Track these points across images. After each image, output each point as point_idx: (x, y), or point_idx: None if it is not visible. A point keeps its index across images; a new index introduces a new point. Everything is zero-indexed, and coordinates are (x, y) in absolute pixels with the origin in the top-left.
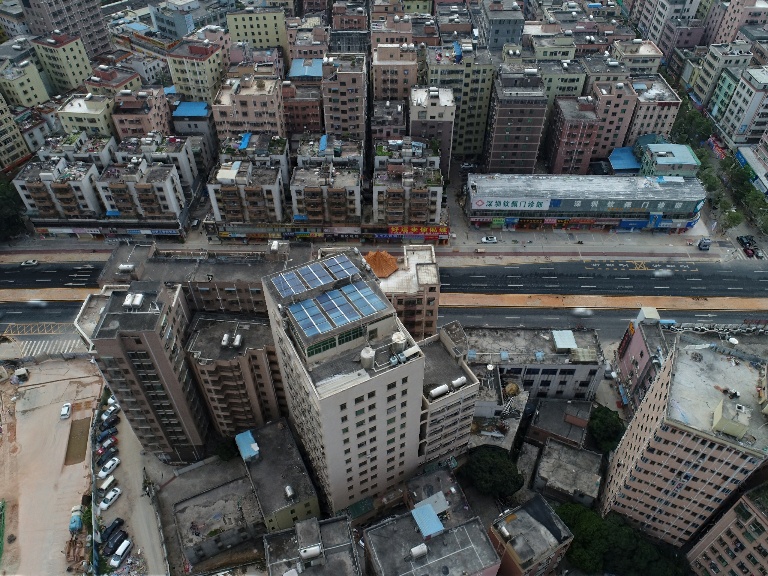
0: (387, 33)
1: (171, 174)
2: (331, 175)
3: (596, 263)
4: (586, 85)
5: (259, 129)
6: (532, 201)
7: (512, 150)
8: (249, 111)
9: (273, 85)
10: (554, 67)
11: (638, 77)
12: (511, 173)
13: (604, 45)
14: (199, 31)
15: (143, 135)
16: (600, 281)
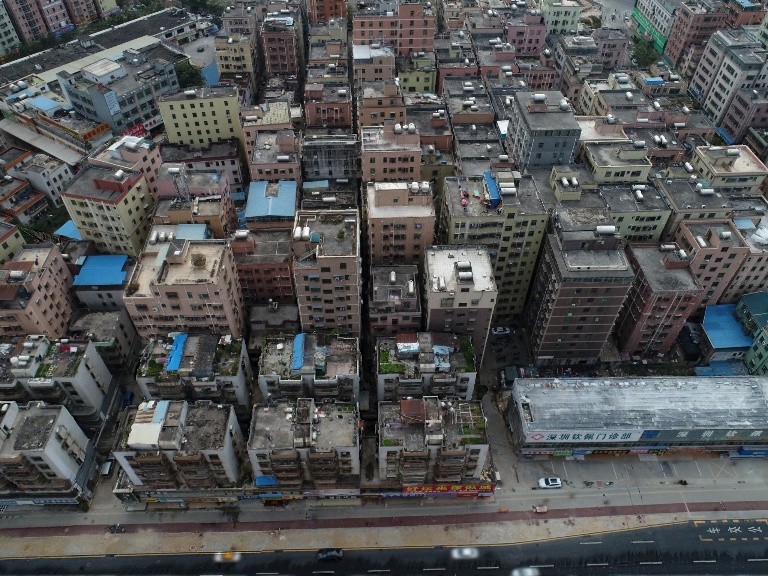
0: (385, 151)
1: (56, 428)
2: (312, 424)
3: (714, 527)
4: (669, 222)
5: (200, 323)
6: (616, 433)
7: (574, 332)
8: (182, 303)
9: (218, 258)
10: (623, 196)
11: (734, 202)
12: (569, 355)
13: (681, 151)
14: (112, 148)
15: (20, 338)
16: (727, 568)
